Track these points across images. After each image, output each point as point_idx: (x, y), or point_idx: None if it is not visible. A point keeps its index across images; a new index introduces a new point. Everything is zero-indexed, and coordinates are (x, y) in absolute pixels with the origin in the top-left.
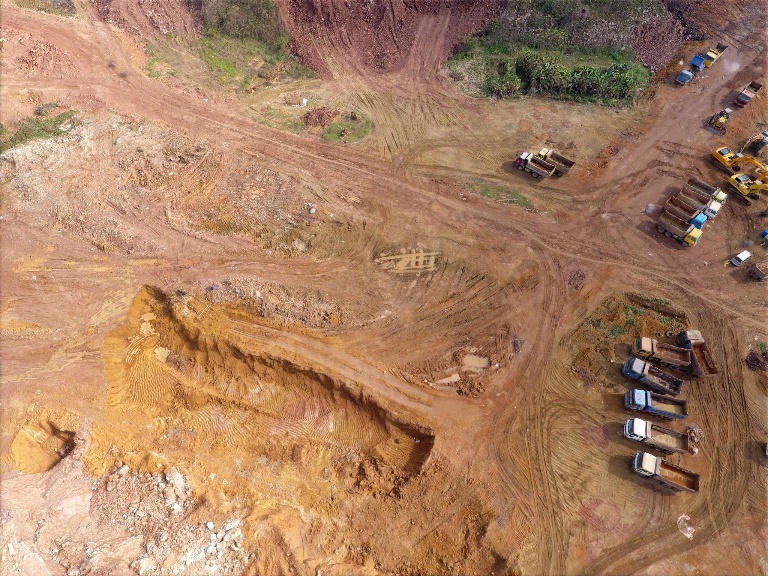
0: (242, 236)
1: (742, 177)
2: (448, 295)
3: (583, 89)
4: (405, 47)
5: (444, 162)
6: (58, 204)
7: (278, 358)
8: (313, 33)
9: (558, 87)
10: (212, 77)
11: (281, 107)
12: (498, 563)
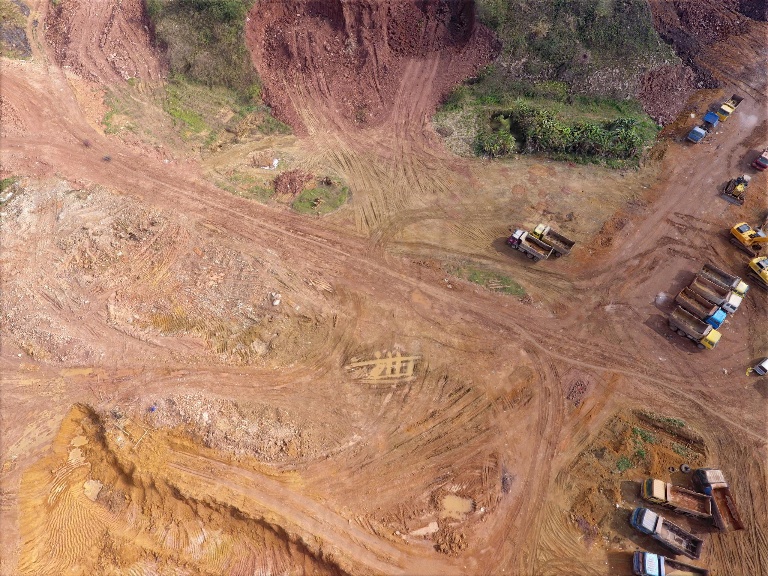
0: (193, 337)
1: (765, 262)
2: (427, 413)
3: (584, 149)
4: (389, 97)
5: (428, 238)
6: None
7: (224, 503)
8: (288, 80)
9: (556, 147)
10: (175, 132)
11: (249, 170)
12: None
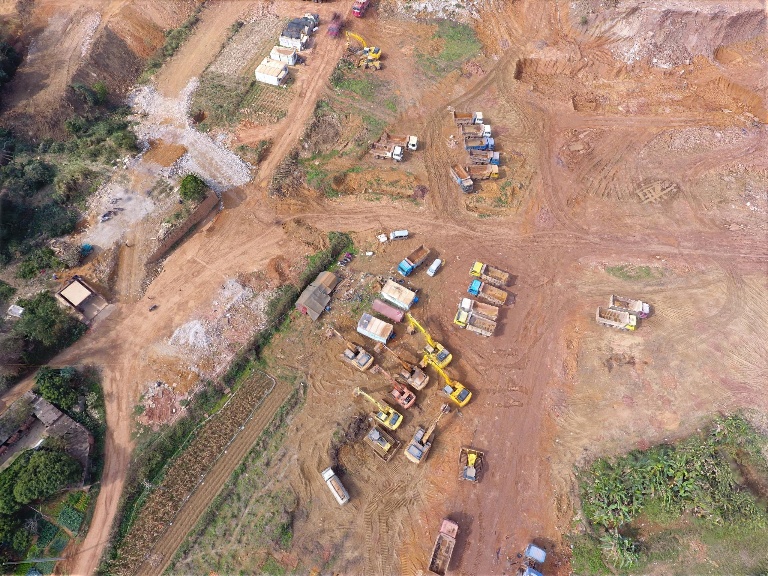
0: (767, 169)
1: (445, 354)
2: None
3: None
4: None
5: (702, 294)
6: None
7: None
8: None
9: None
10: None
11: None
12: None
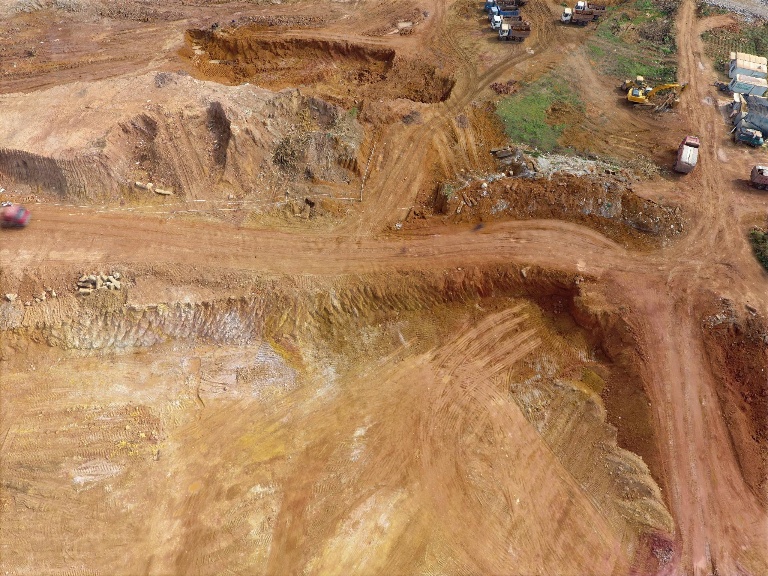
0: None
1: None
2: (379, 4)
3: None
4: None
5: None
6: (99, 7)
7: (291, 39)
8: None
9: None
10: None
11: None
12: (445, 84)
